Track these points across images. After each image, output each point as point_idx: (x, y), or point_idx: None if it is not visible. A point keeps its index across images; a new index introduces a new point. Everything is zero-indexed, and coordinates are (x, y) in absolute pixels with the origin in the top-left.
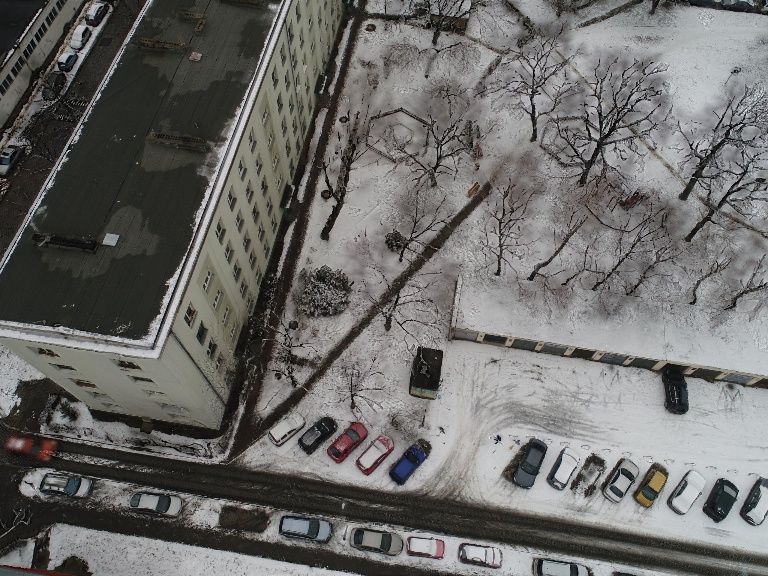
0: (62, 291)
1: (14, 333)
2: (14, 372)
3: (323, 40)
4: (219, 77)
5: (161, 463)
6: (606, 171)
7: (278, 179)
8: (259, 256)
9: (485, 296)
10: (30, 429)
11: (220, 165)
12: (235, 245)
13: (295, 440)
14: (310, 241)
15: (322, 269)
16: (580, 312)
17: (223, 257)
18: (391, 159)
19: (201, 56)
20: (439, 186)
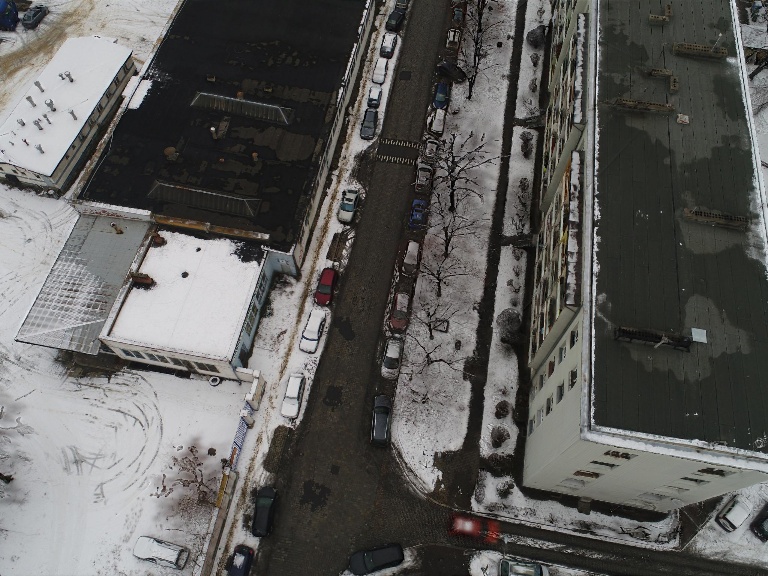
0: (675, 396)
1: (639, 444)
2: (426, 442)
3: None
4: (717, 142)
5: (610, 548)
6: None
7: None
8: None
9: None
10: (461, 506)
11: (767, 246)
12: None
13: (744, 525)
14: None
15: None
16: None
17: None
18: None
19: (688, 118)
20: None
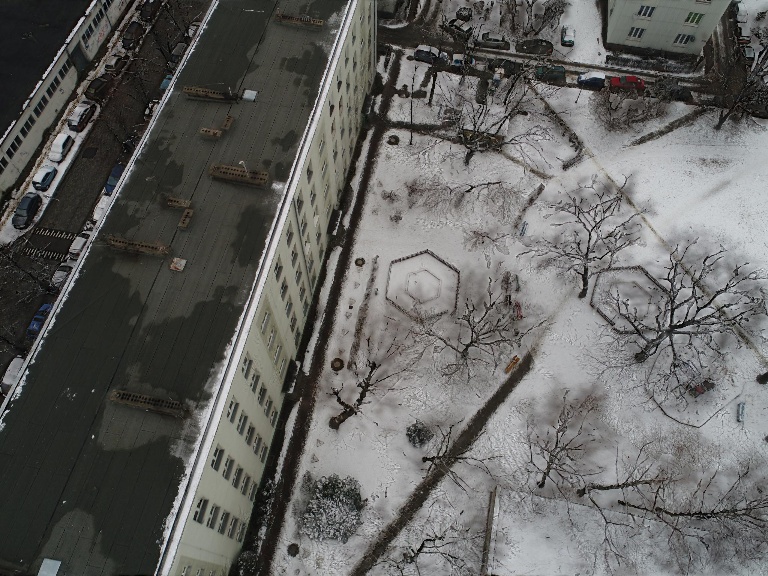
0: None
1: None
2: None
3: (338, 170)
4: (206, 296)
5: None
6: (677, 368)
7: (280, 366)
8: (254, 471)
9: (527, 527)
10: None
11: (201, 439)
12: (221, 499)
13: None
14: (316, 430)
15: (330, 485)
16: (644, 554)
17: (204, 531)
18: None
19: (185, 264)
20: (471, 359)
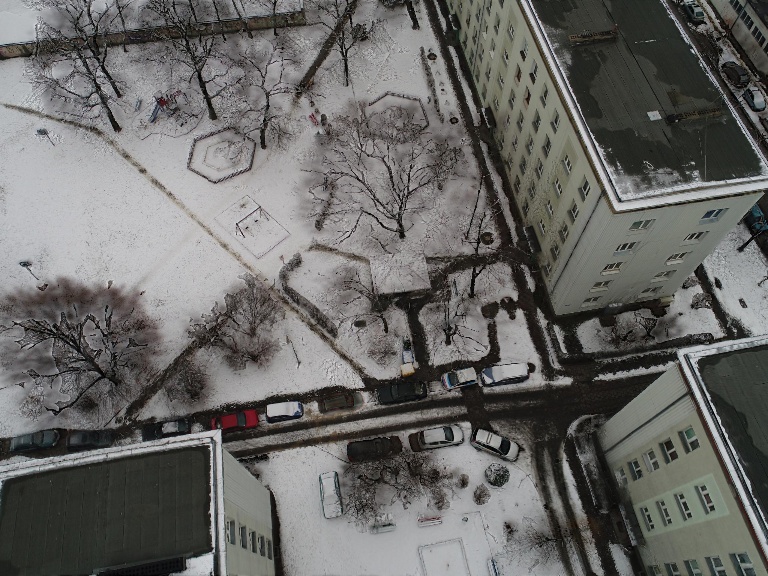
0: None
1: None
2: None
3: None
4: None
5: None
6: None
7: None
8: None
9: (281, 0)
10: None
11: None
12: None
13: None
14: (425, 24)
15: None
16: (212, 7)
17: None
18: (392, 94)
19: None
20: None
